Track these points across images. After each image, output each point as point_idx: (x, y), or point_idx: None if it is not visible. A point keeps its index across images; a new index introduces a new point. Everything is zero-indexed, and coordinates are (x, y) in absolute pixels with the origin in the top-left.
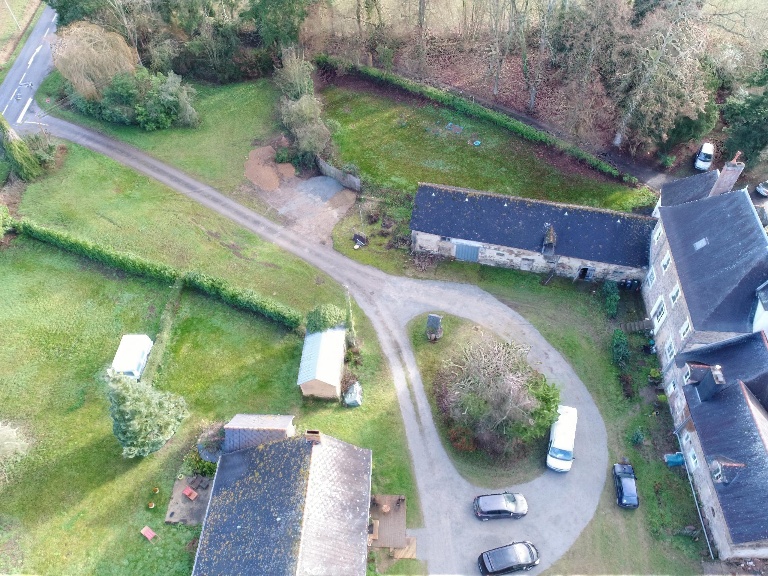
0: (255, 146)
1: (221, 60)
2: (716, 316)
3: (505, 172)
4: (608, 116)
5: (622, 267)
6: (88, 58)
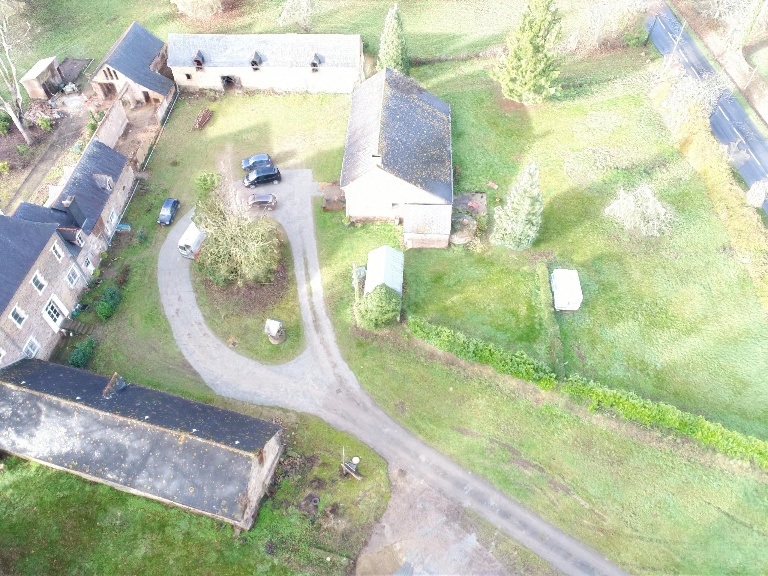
0: None
1: None
2: None
3: None
4: None
5: None
6: None
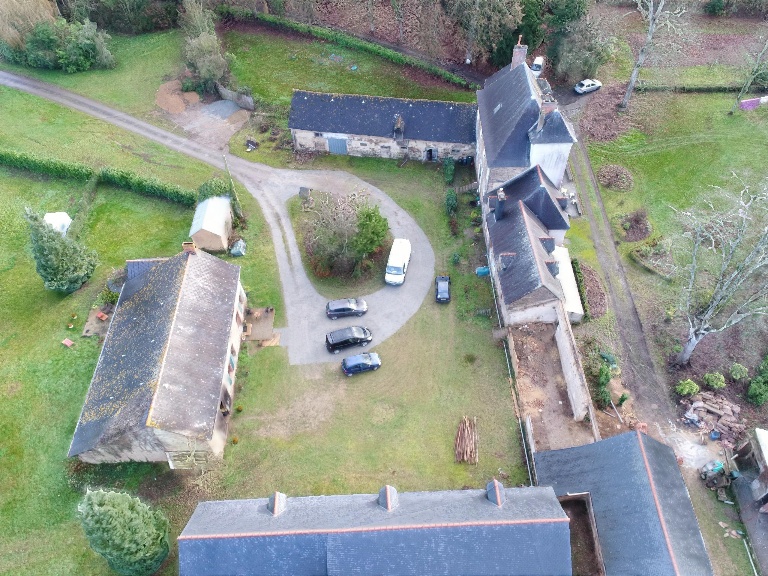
0: (165, 81)
1: (134, 13)
2: (502, 155)
3: (375, 88)
4: (447, 31)
5: (457, 145)
6: (11, 9)
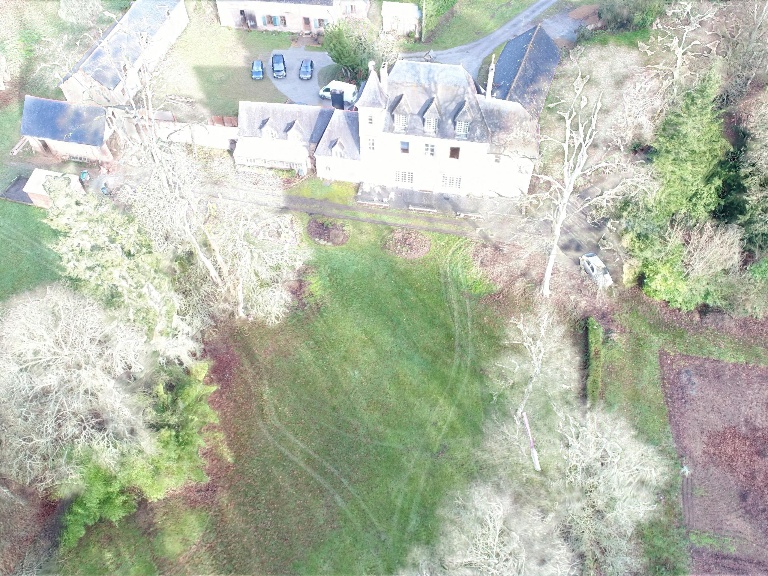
0: None
1: None
2: None
3: None
4: None
5: None
6: None
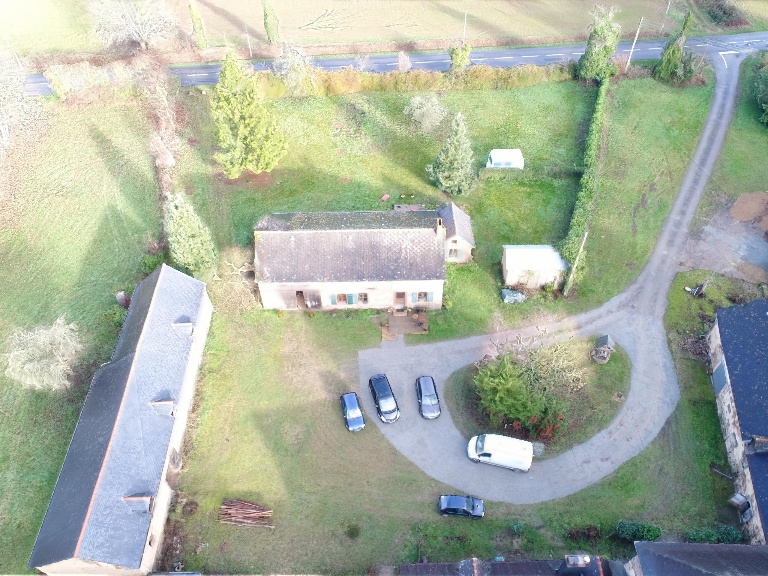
0: None
1: None
2: (660, 563)
3: None
4: None
5: None
6: None
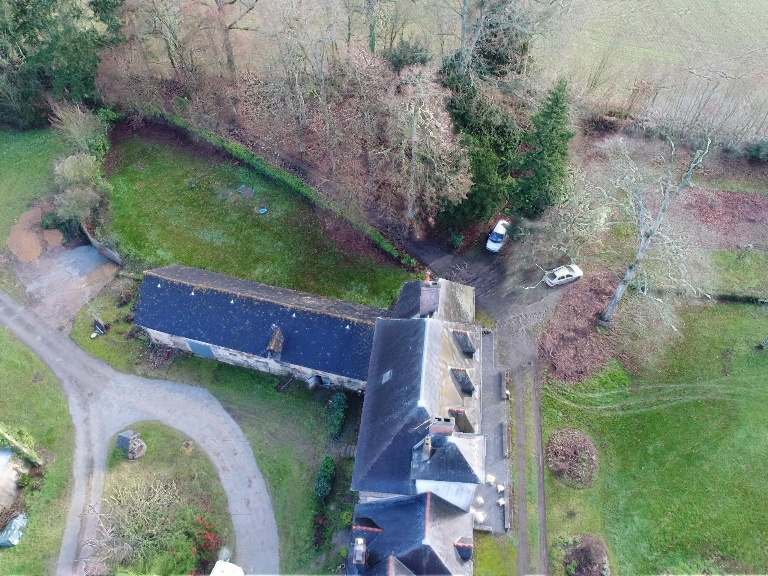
0: (31, 207)
1: (21, 105)
2: (374, 474)
3: (281, 248)
4: (367, 197)
5: None
6: None
